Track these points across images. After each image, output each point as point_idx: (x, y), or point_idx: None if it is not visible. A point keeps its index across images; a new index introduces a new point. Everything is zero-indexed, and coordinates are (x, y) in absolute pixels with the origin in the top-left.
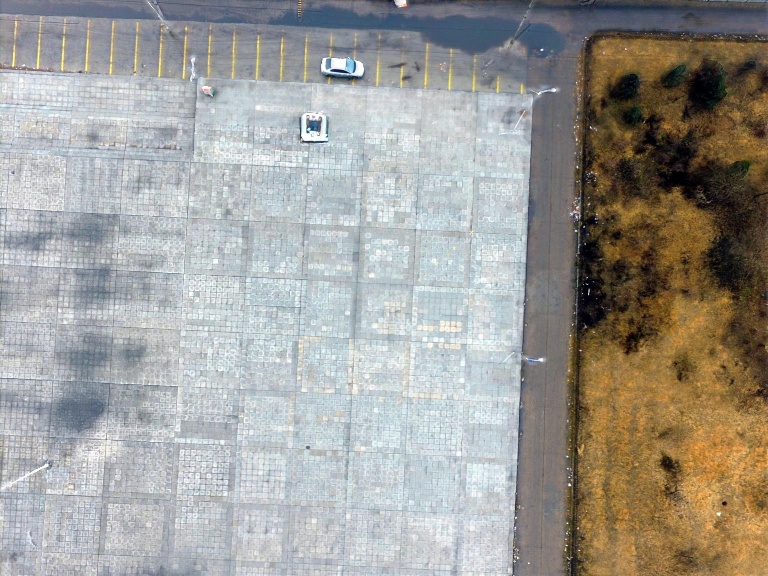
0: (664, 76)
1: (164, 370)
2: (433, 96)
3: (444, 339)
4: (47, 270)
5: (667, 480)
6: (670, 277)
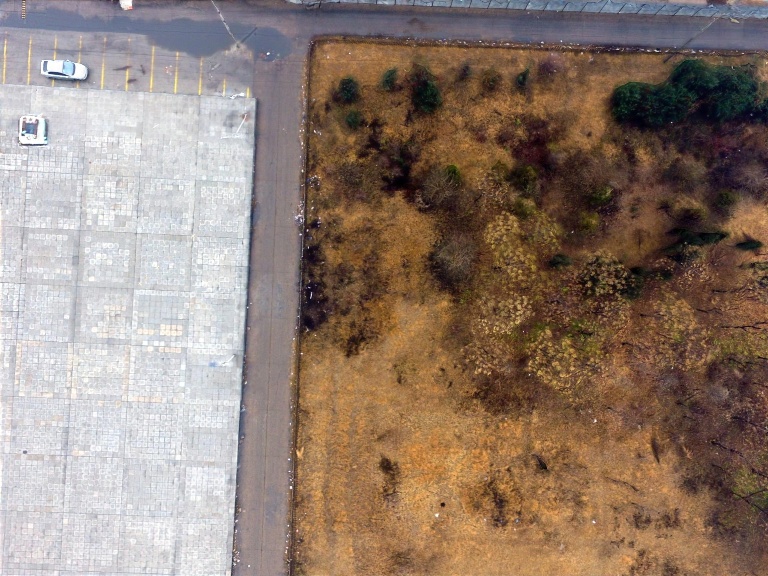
0: None
1: None
2: (155, 99)
3: (164, 343)
4: None
5: (386, 482)
6: (391, 280)
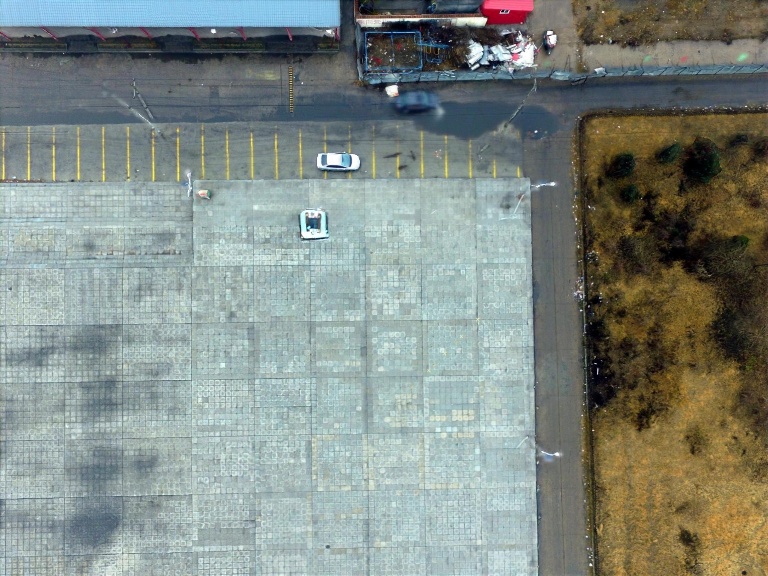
0: (658, 152)
1: (177, 479)
2: (431, 185)
3: (457, 428)
4: (51, 386)
5: (686, 554)
6: (677, 351)
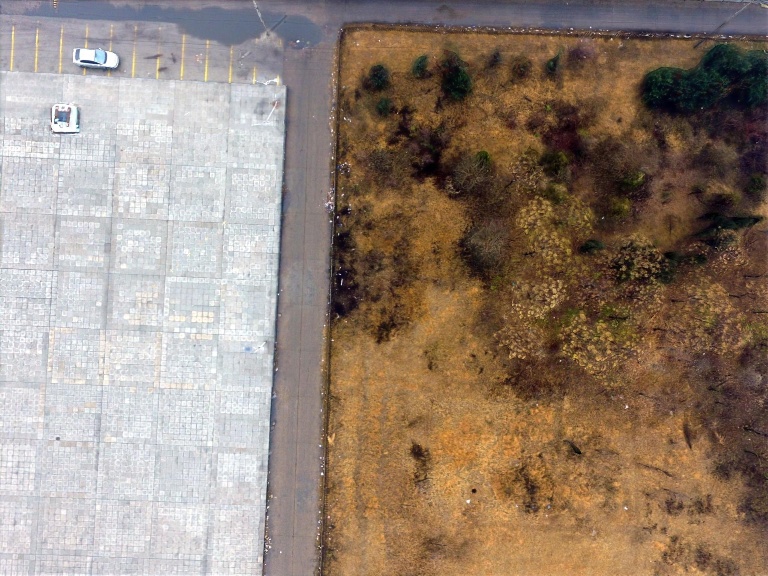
0: None
1: None
2: (186, 87)
3: (196, 329)
4: None
5: (417, 468)
6: (421, 267)
